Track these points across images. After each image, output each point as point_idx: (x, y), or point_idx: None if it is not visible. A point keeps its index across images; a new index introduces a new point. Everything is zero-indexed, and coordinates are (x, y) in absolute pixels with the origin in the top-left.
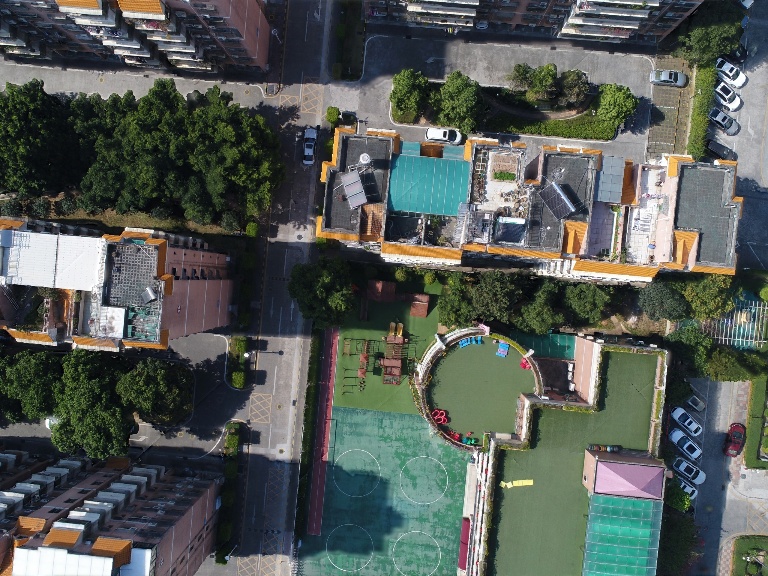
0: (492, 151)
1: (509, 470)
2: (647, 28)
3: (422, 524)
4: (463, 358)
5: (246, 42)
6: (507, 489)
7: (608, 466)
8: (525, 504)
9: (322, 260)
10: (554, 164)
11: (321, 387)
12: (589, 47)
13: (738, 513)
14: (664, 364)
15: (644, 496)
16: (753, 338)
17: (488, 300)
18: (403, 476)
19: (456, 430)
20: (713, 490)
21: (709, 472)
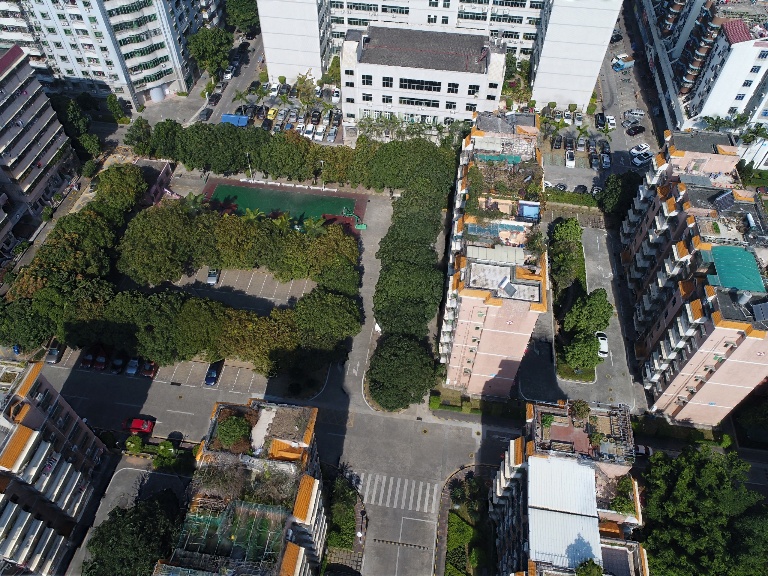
0: None
1: None
2: None
3: None
4: None
5: None
6: None
7: None
8: None
9: None
10: (696, 205)
11: None
12: None
13: None
14: (766, 195)
15: None
16: None
17: None
18: None
19: None
20: None
21: None
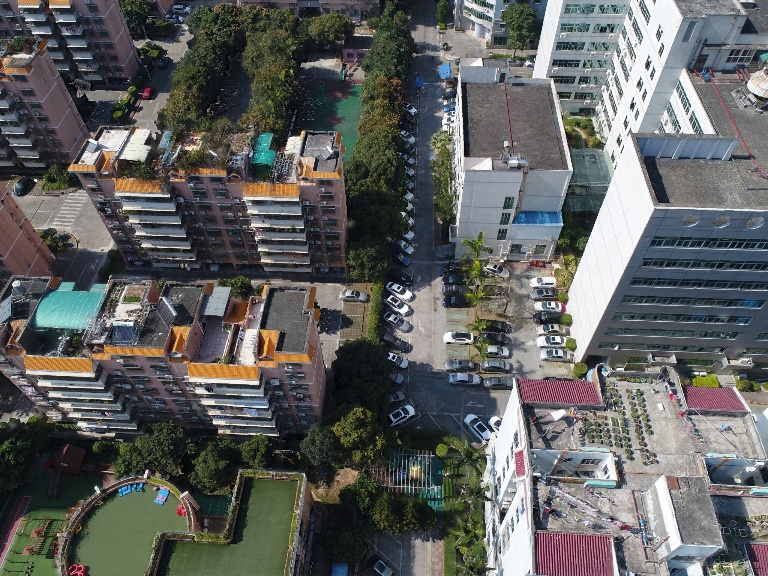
0: (128, 285)
1: None
2: (327, 260)
3: None
4: (120, 507)
5: (8, 263)
6: None
7: None
8: None
9: (13, 422)
10: (174, 292)
11: None
12: (295, 280)
13: None
14: (301, 487)
15: None
16: (421, 485)
17: (151, 443)
18: None
19: None
20: None
21: None
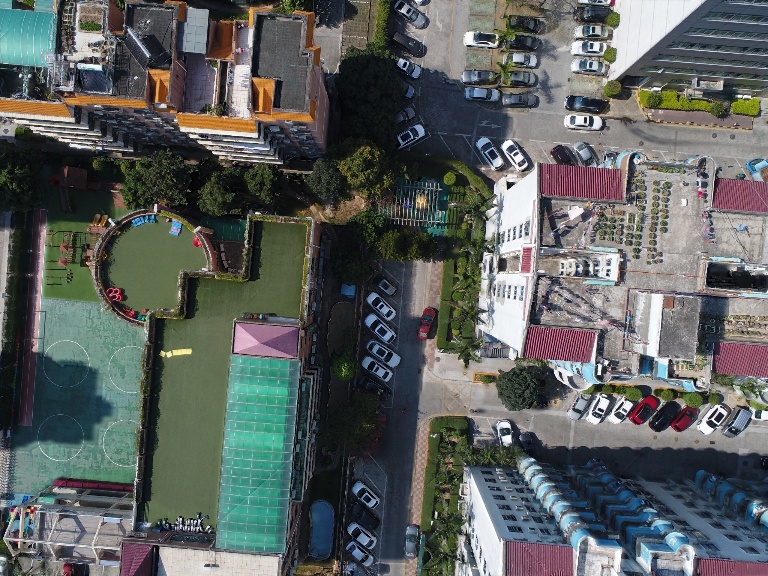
0: (80, 3)
1: (168, 340)
2: None
3: (131, 413)
4: (138, 237)
5: None
6: (167, 358)
7: (243, 326)
8: (184, 373)
9: (1, 143)
10: (140, 15)
11: (30, 279)
12: None
13: (434, 395)
14: (310, 232)
15: (280, 355)
16: (427, 218)
17: (153, 177)
18: (112, 366)
19: (132, 308)
20: (410, 373)
21: (406, 356)
